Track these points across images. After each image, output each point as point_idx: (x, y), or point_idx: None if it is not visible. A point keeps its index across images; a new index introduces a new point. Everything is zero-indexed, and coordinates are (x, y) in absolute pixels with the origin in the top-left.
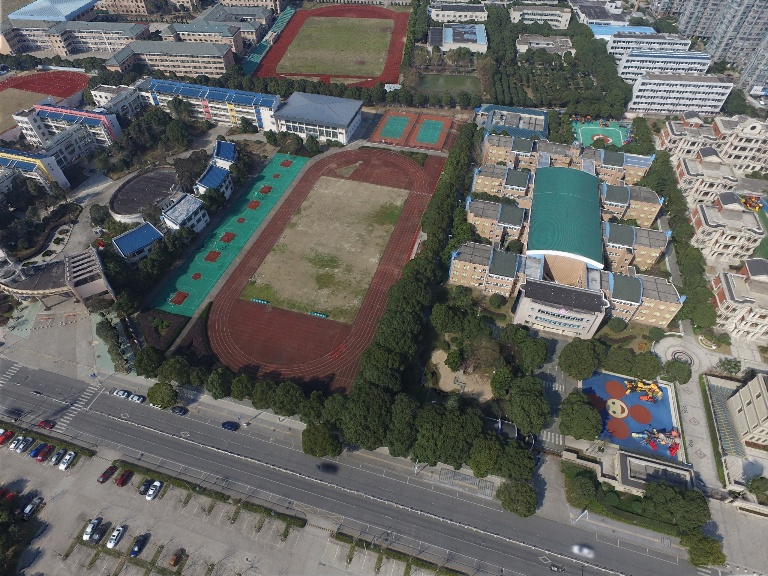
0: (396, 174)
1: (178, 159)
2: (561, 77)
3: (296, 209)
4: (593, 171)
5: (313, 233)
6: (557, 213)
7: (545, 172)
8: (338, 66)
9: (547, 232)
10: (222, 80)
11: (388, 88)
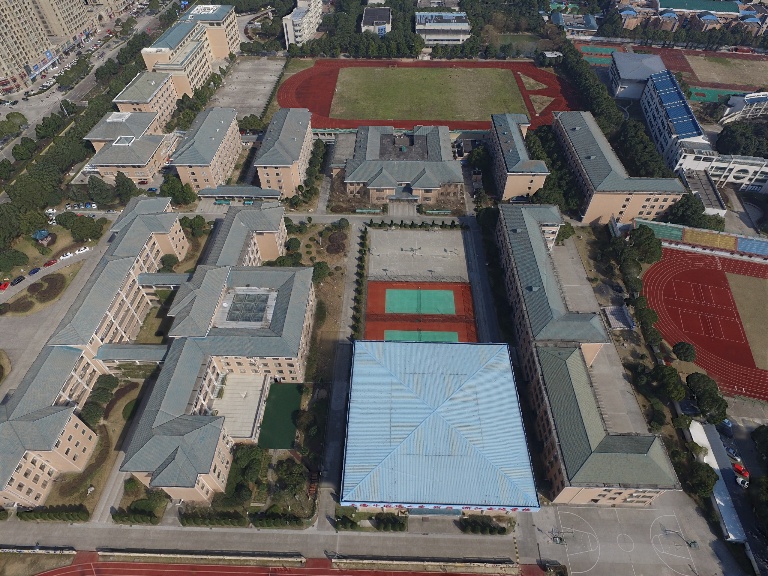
0: (670, 59)
1: (767, 128)
2: (494, 5)
3: (749, 86)
4: (640, 1)
5: (765, 79)
6: (705, 3)
7: (665, 4)
8: (496, 88)
9: (723, 6)
10: (624, 119)
11: (555, 56)
